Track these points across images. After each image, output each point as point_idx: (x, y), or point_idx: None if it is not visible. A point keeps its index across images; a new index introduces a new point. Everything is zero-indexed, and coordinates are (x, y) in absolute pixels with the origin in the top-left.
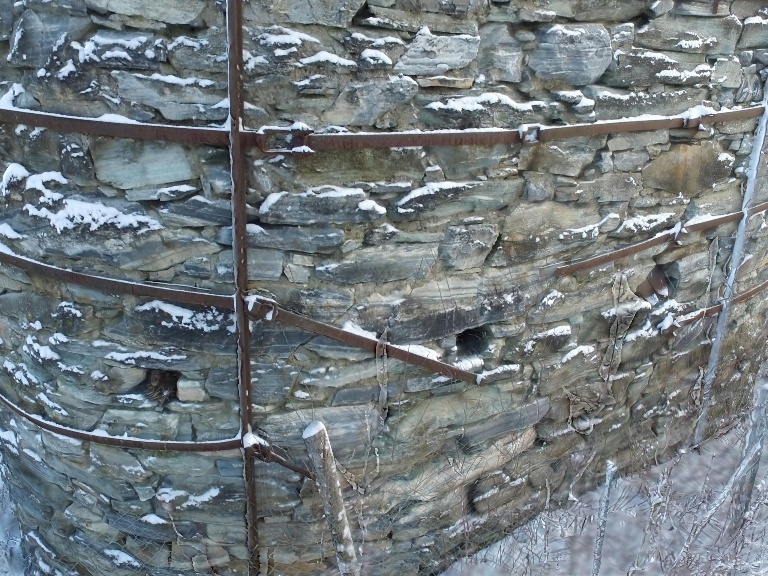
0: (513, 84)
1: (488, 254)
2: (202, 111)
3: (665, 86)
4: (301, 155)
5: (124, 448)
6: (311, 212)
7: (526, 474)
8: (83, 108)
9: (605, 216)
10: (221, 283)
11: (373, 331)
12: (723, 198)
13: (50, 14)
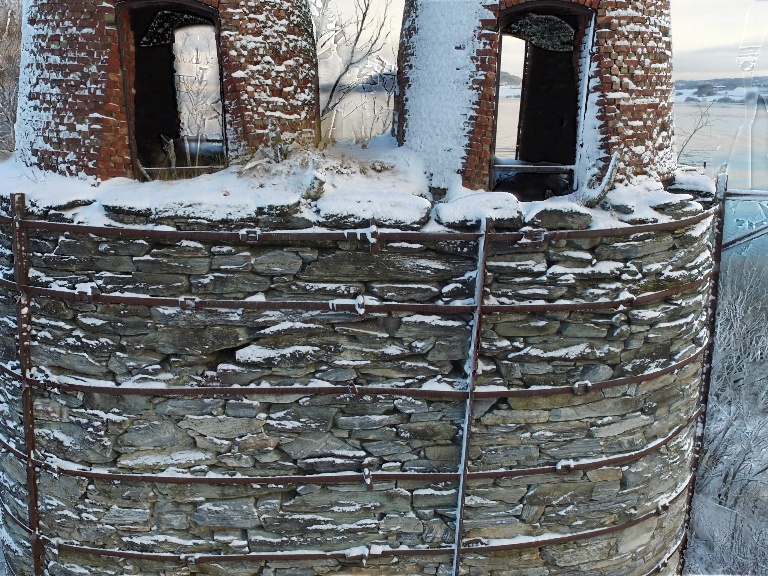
0: (181, 530)
1: None
2: None
3: None
4: None
5: None
6: (65, 575)
7: None
8: None
9: None
10: None
11: None
12: None
13: None
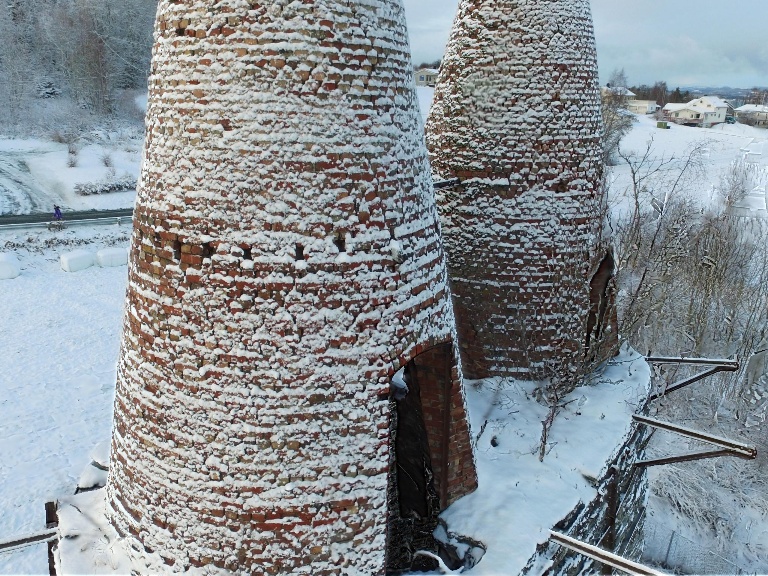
0: None
1: None
2: None
3: None
4: None
5: None
6: None
7: None
8: None
9: None
10: None
11: None
12: None
13: None
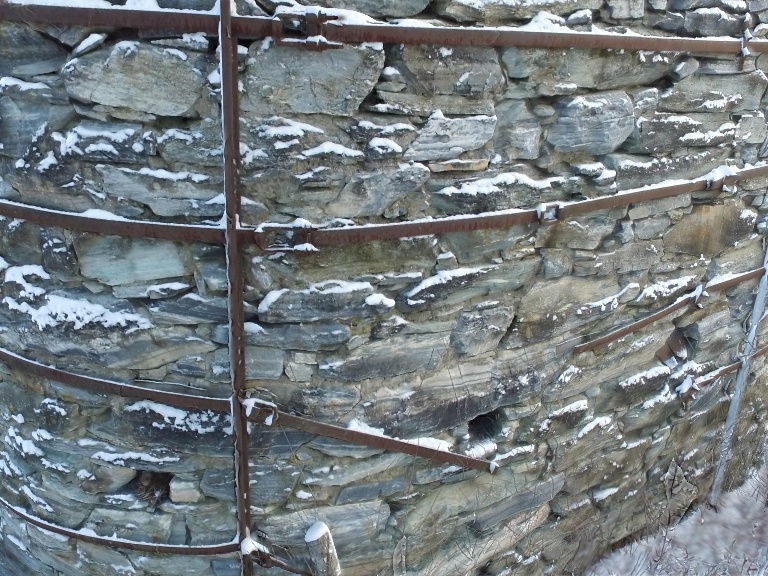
0: (531, 161)
1: (502, 337)
2: (195, 207)
3: (688, 148)
4: (303, 254)
5: (113, 547)
6: (314, 310)
7: (539, 551)
8: (66, 201)
9: (625, 286)
10: (217, 383)
11: (380, 427)
12: (745, 255)
13: (29, 102)
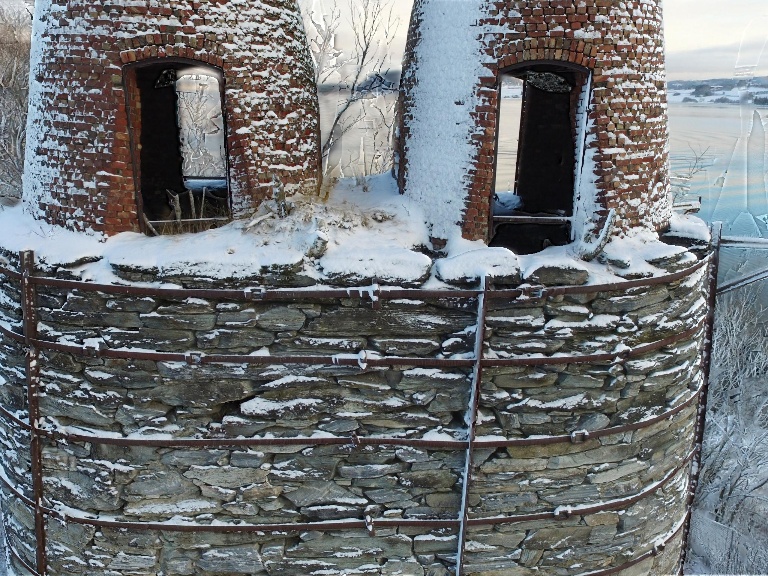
0: (186, 575)
1: None
2: None
3: None
4: None
5: None
6: None
7: None
8: None
9: None
10: None
11: None
12: None
13: None
